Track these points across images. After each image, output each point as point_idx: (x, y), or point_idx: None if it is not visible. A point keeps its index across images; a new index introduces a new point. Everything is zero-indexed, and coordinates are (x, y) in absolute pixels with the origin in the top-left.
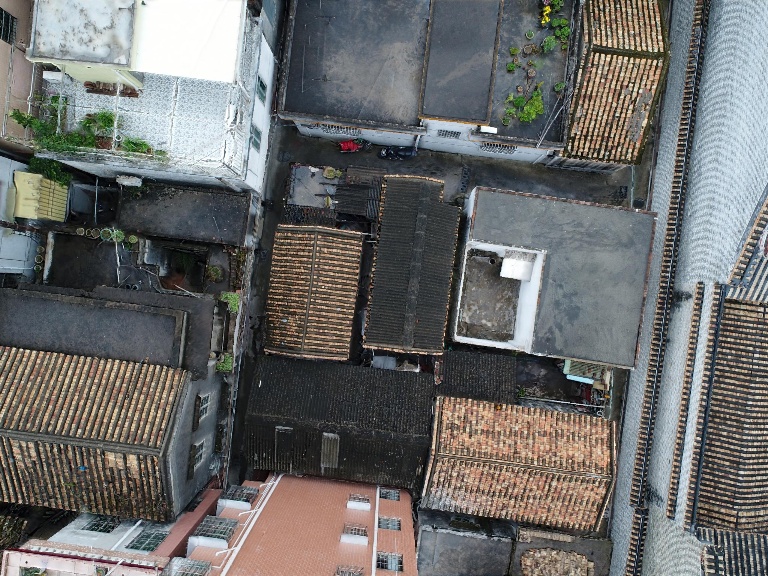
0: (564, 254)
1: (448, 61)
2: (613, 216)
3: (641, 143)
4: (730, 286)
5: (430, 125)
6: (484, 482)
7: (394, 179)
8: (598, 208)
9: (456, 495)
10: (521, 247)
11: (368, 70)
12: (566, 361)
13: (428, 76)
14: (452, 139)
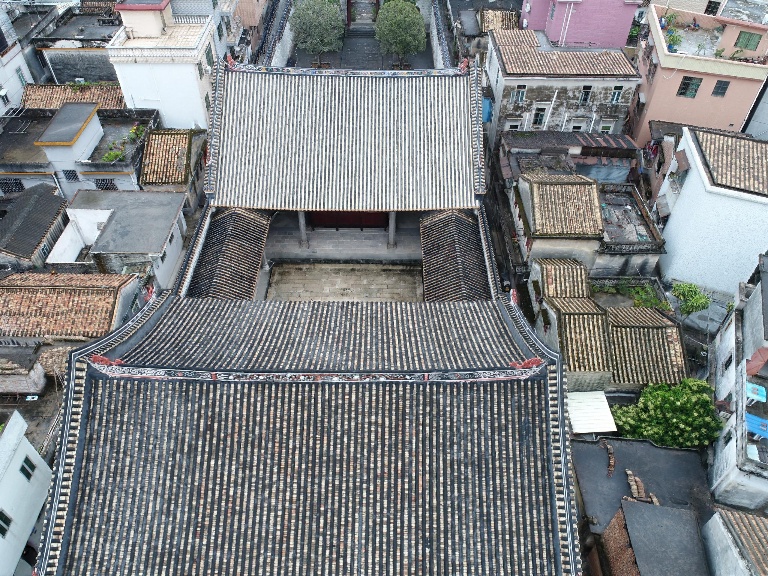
0: (126, 211)
1: (58, 127)
2: (160, 195)
3: (185, 172)
4: (210, 197)
5: (54, 164)
6: (24, 306)
7: (27, 189)
8: (152, 193)
9: (2, 321)
10: (98, 209)
11: (30, 154)
12: (124, 267)
13: (45, 131)
14: (78, 185)
